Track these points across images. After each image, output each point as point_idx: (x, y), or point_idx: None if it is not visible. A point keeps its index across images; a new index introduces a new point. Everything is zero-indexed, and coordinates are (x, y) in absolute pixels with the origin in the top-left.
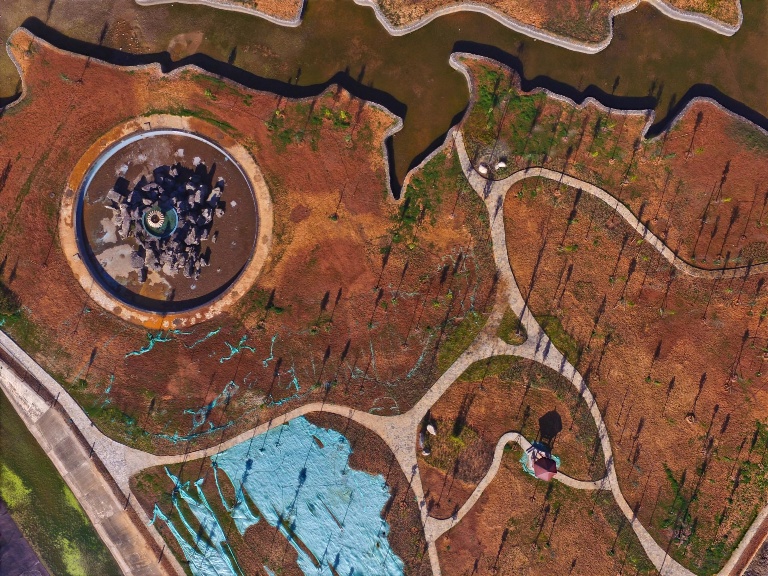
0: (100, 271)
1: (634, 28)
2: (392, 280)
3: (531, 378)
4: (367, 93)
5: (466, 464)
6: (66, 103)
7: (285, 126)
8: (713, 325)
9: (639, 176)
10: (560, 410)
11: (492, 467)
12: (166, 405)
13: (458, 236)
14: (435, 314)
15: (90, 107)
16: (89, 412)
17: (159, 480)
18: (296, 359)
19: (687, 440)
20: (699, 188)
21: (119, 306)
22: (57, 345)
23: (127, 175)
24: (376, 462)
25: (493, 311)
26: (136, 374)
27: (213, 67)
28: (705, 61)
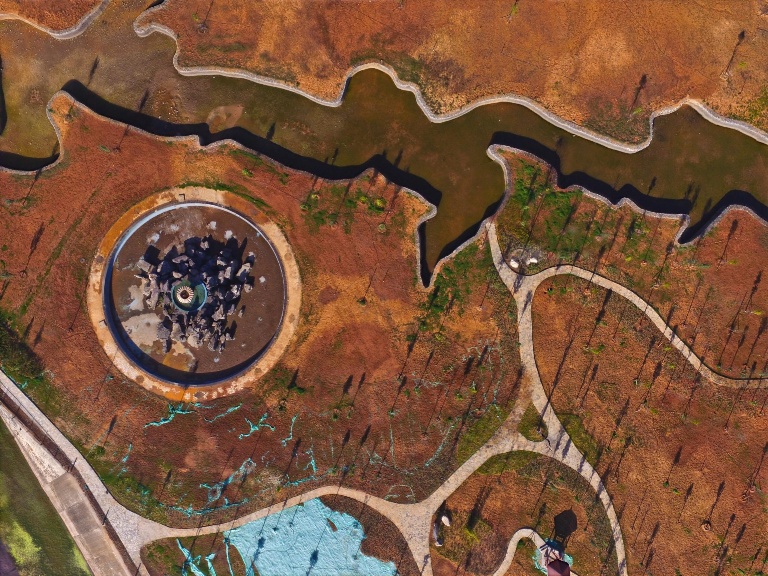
0: (125, 338)
1: (674, 130)
2: (416, 368)
3: (549, 476)
4: (403, 177)
5: (479, 557)
6: (102, 170)
7: (319, 207)
8: (735, 434)
9: (670, 280)
10: (576, 510)
11: (504, 562)
12: (182, 478)
13: (485, 328)
14: (457, 405)
15: (126, 175)
16: (105, 479)
17: (170, 552)
18: (315, 441)
19: (701, 548)
20: (729, 296)
21: (142, 375)
22: (78, 411)
23: (158, 244)
24: (389, 549)
25: (515, 406)
26: (154, 445)
27: (251, 141)
28: (743, 168)
